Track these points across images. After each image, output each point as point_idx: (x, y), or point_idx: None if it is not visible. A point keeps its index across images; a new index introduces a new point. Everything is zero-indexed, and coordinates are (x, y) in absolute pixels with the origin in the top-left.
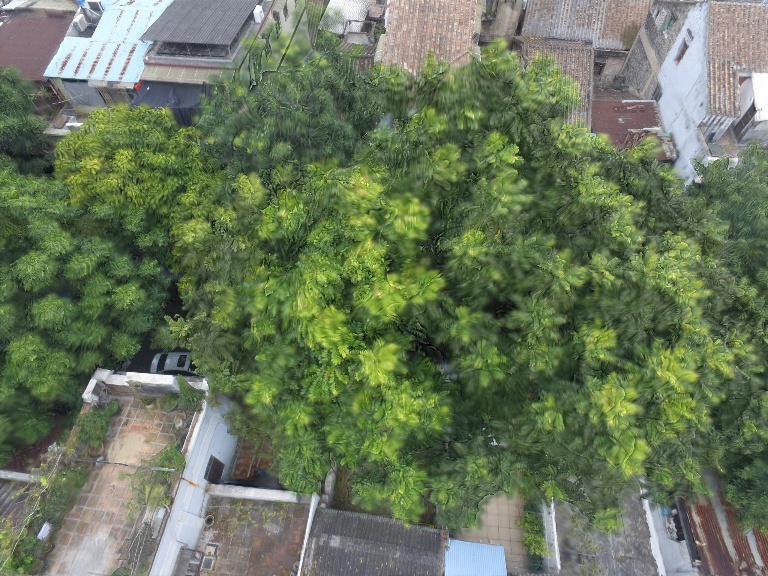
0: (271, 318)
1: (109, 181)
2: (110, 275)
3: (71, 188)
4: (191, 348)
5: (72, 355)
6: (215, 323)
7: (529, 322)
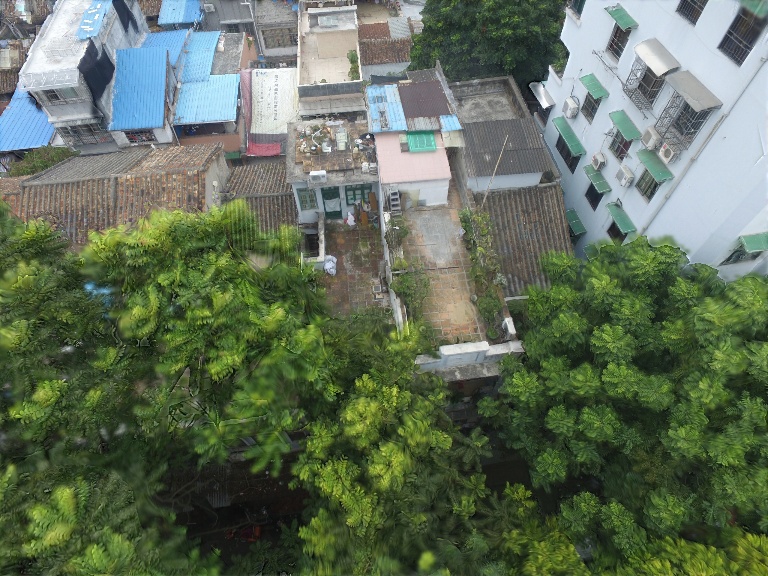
0: (297, 305)
1: (703, 572)
2: (561, 407)
3: (766, 561)
4: (438, 379)
5: (538, 332)
6: (387, 348)
7: (4, 221)
